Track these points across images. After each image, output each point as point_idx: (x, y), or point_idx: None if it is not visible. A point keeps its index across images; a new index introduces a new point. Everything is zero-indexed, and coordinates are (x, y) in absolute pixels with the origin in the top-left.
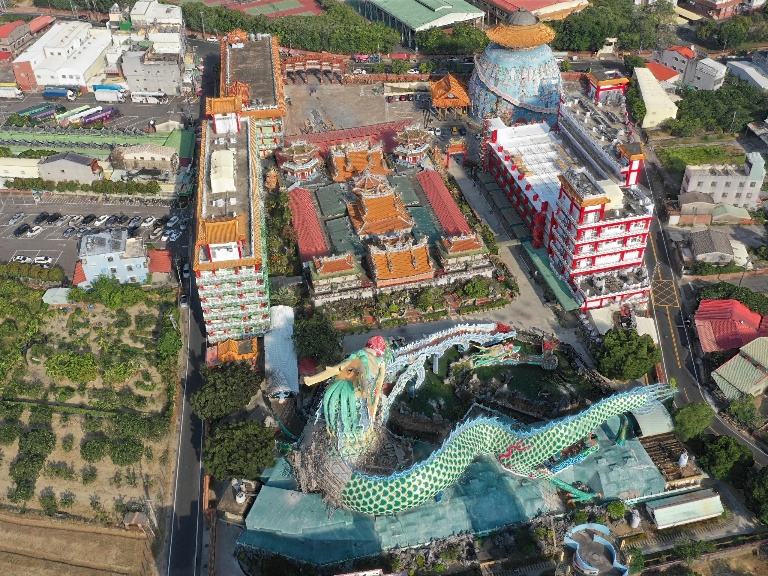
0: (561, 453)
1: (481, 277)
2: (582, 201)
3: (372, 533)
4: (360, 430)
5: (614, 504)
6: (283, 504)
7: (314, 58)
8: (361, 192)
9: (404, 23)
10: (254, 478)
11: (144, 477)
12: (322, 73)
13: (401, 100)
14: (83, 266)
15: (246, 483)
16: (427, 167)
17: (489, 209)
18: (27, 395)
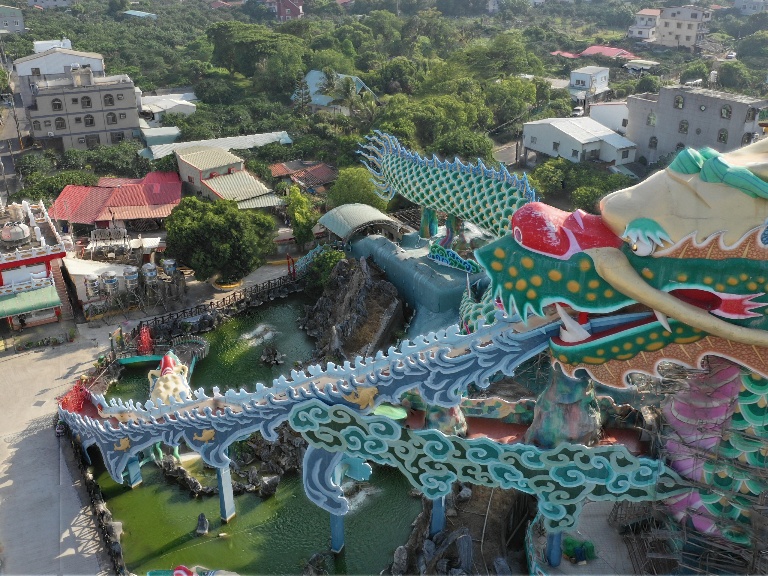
0: None
1: None
2: None
3: None
4: None
5: None
6: None
7: None
8: None
9: None
10: None
11: None
12: None
13: None
14: None
15: None
16: None
17: None
18: None
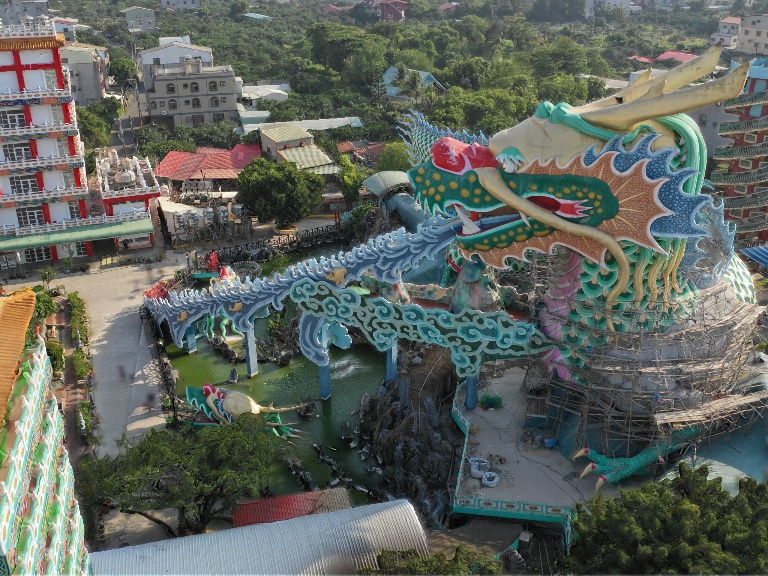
0: None
1: None
2: (54, 39)
3: None
4: None
5: None
6: None
7: None
8: None
9: None
10: None
11: None
12: None
13: None
14: None
15: None
16: None
17: None
18: None
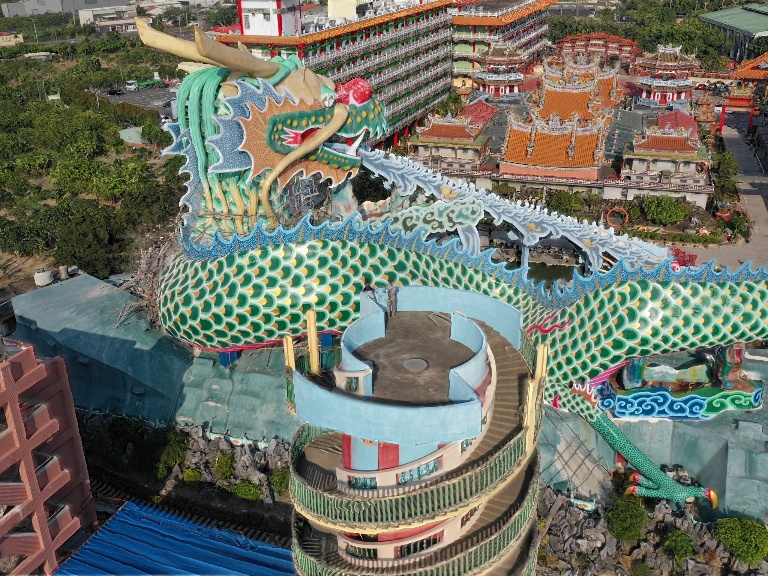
0: (649, 381)
1: (682, 199)
2: None
3: (173, 382)
4: (229, 182)
5: (738, 520)
6: (79, 294)
7: (599, 36)
8: (543, 78)
9: (742, 32)
10: (100, 277)
11: (14, 270)
12: (606, 58)
13: (697, 88)
14: (172, 103)
15: (79, 274)
16: (678, 107)
17: (758, 168)
18: (6, 184)
